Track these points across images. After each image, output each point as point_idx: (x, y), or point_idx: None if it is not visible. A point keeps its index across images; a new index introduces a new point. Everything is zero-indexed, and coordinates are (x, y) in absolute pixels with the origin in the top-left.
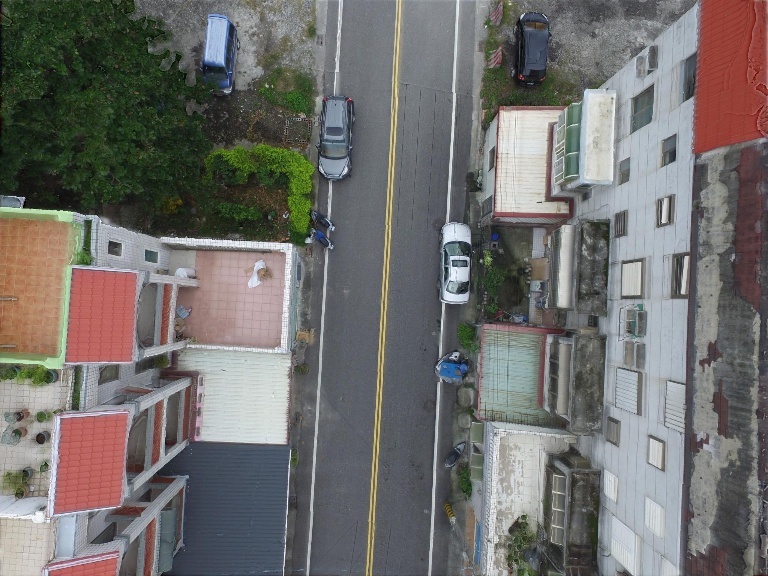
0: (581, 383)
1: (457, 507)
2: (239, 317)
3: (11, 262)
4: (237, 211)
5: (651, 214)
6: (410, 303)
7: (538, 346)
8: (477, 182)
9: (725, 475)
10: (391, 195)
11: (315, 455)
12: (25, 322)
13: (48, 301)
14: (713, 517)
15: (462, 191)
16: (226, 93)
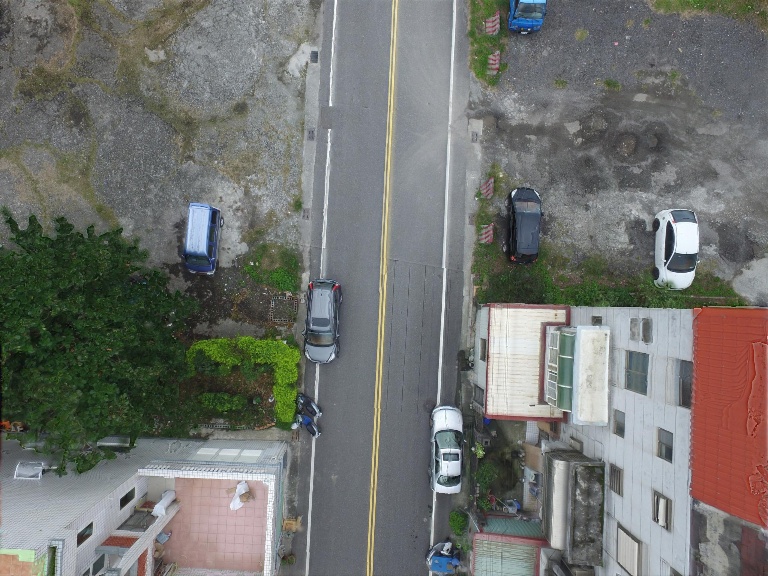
0: None
1: None
2: (221, 541)
3: None
4: (221, 401)
5: (647, 496)
6: (400, 489)
7: (532, 558)
8: (469, 361)
9: None
10: (380, 377)
11: None
12: None
13: None
14: None
15: (453, 370)
16: (209, 274)
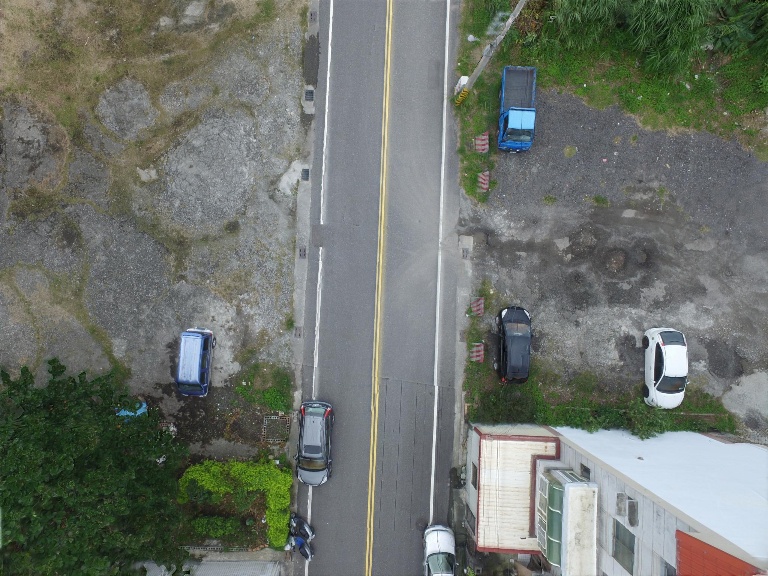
0: None
1: None
2: None
3: None
4: (214, 527)
5: None
6: None
7: None
8: (461, 478)
9: None
10: (372, 496)
11: None
12: None
13: None
14: None
15: (445, 488)
16: (202, 396)
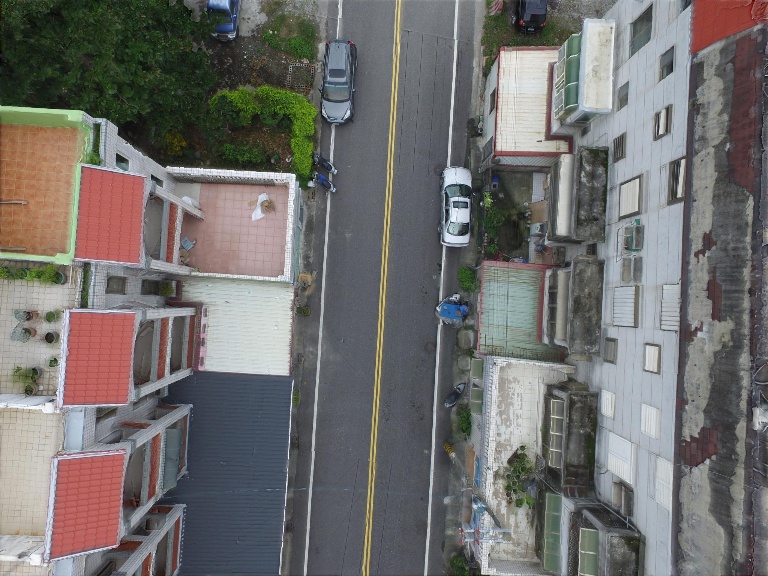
0: (579, 307)
1: (457, 447)
2: (243, 249)
3: (21, 167)
4: (241, 153)
5: (649, 131)
6: (411, 246)
7: (537, 282)
8: (478, 128)
9: (718, 357)
10: (393, 140)
11: (317, 395)
12: (35, 226)
13: (57, 206)
14: (707, 400)
15: (463, 137)
16: (230, 38)
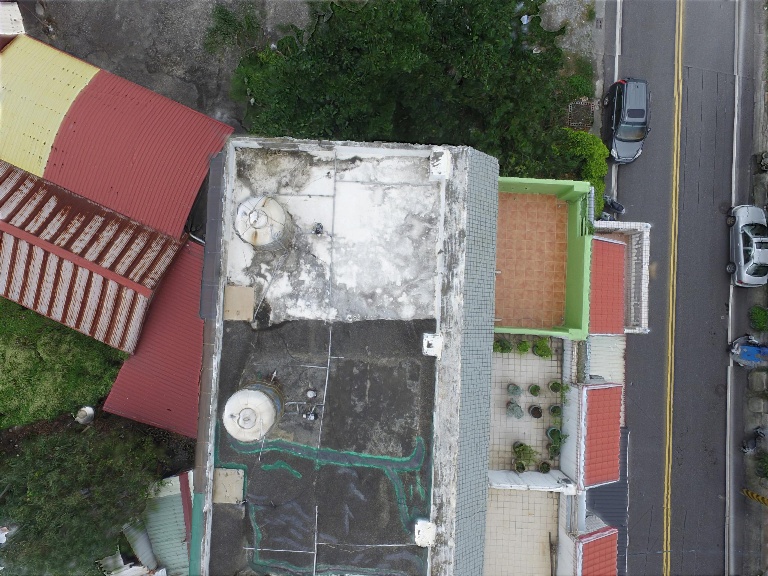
0: None
1: None
2: None
3: None
4: None
5: None
6: (698, 287)
7: None
8: (761, 165)
9: None
10: (677, 178)
11: None
12: (507, 296)
13: (529, 274)
14: None
15: (746, 174)
16: None
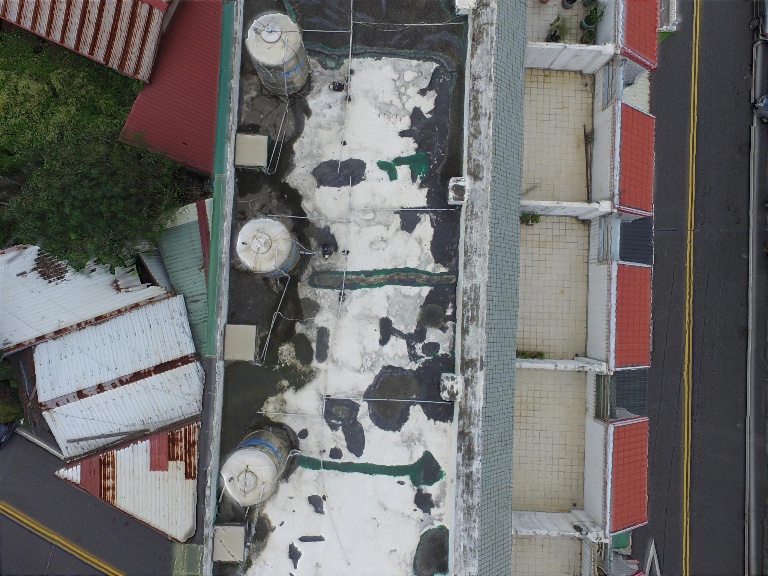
0: None
1: None
2: None
3: None
4: None
5: None
6: (721, 46)
7: None
8: None
9: None
10: None
11: None
12: None
13: None
14: None
15: None
16: None
